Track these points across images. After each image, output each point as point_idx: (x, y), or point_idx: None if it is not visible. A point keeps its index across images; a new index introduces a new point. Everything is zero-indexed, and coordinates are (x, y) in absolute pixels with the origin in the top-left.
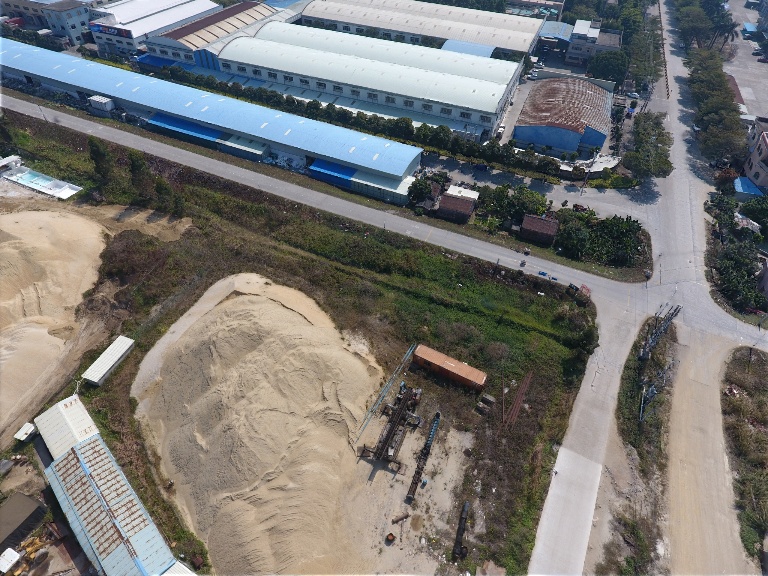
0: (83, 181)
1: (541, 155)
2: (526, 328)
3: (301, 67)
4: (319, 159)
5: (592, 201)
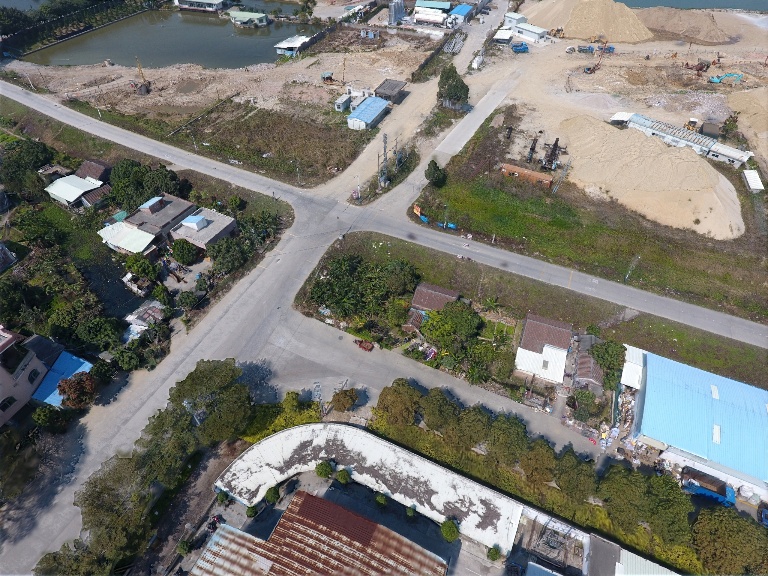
0: None
1: (388, 491)
2: None
3: None
4: None
5: (336, 366)
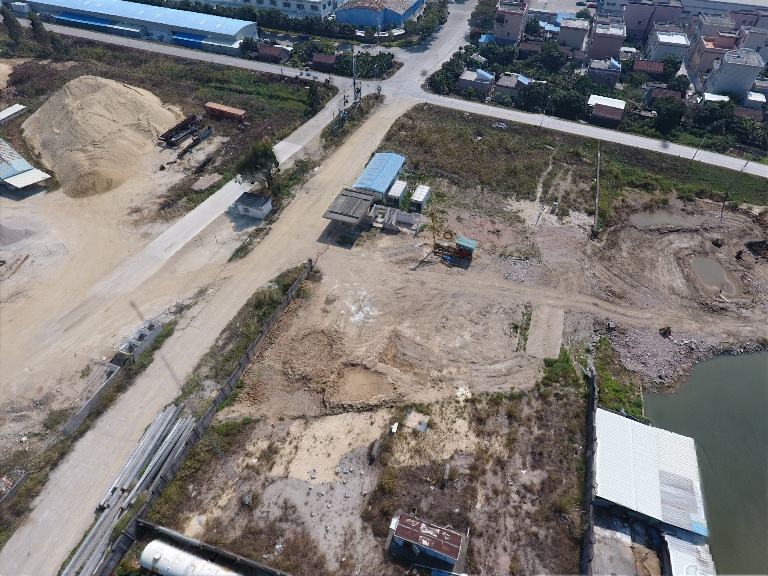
0: (2, 47)
1: None
2: (286, 99)
3: None
4: (180, 32)
5: (376, 52)
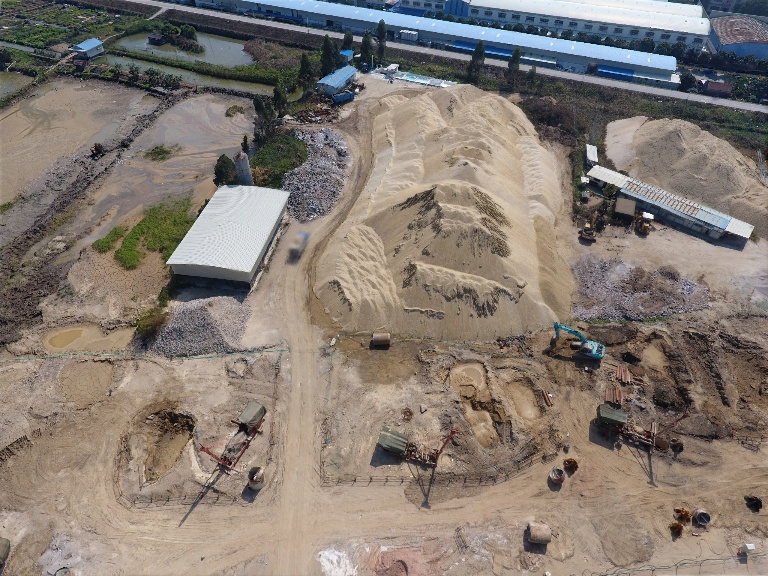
0: (453, 78)
1: None
2: None
3: (541, 9)
4: (601, 65)
5: None
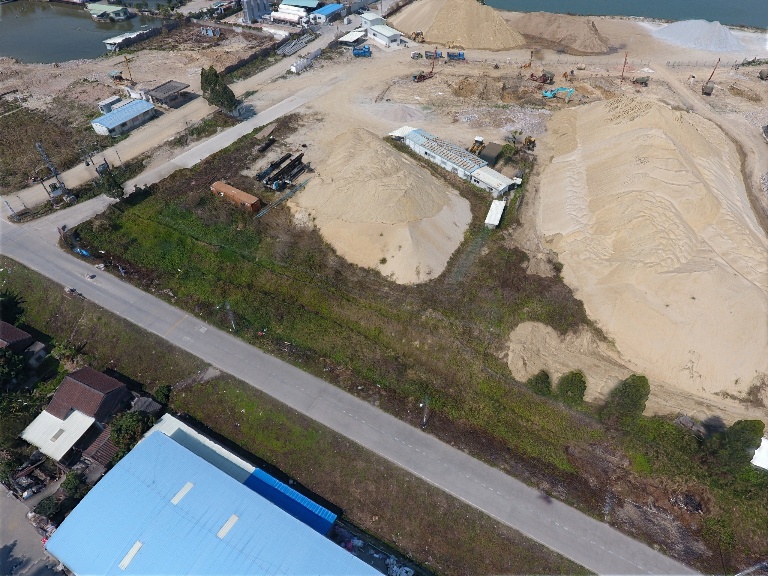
0: (765, 479)
1: None
2: None
3: None
4: None
5: None
